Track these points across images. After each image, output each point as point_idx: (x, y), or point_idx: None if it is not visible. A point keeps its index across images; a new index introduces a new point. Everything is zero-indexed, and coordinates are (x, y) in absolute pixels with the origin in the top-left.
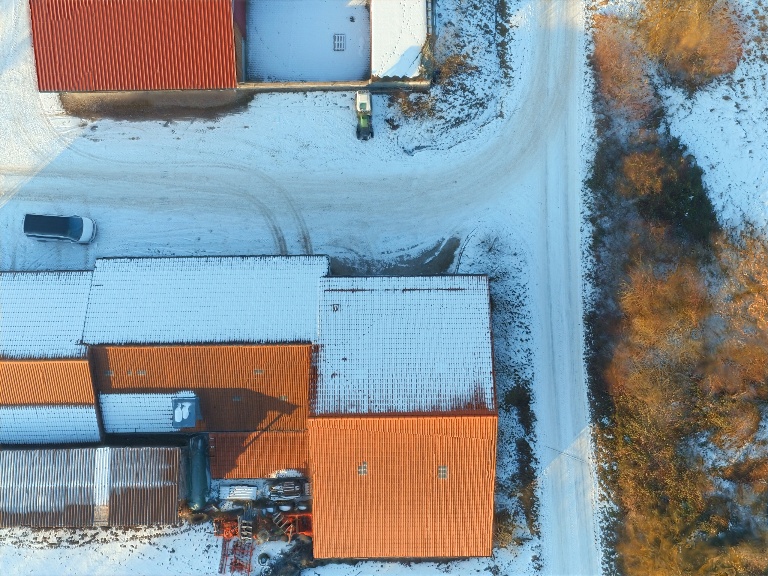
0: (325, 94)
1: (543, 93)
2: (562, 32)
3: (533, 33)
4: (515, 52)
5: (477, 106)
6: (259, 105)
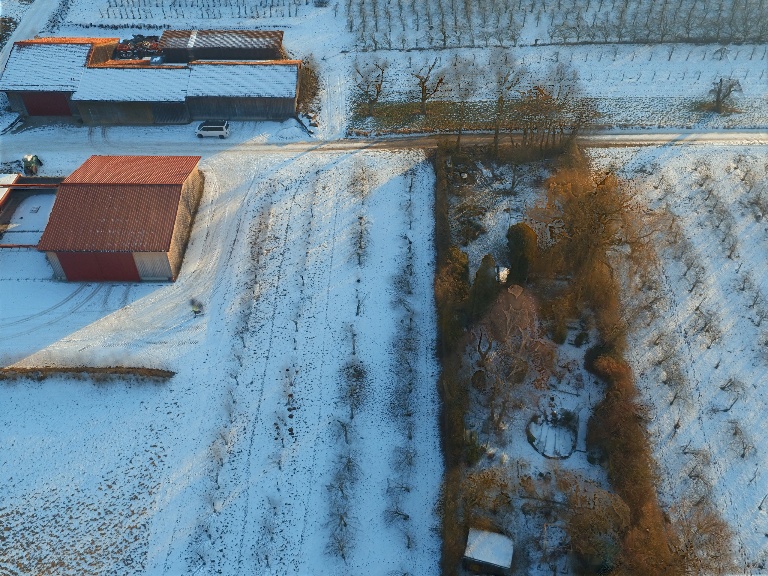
0: None
1: None
2: None
3: None
4: None
5: None
6: None
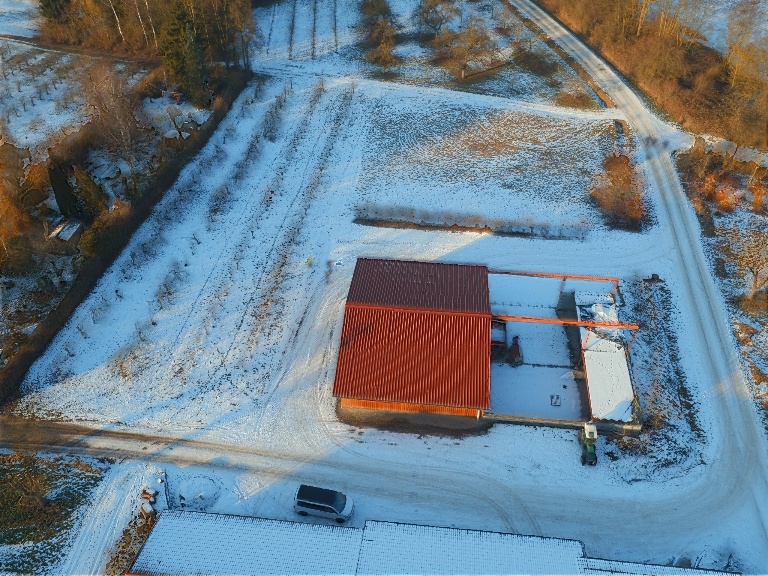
0: (552, 429)
1: (735, 450)
2: (738, 411)
3: (714, 409)
4: (703, 420)
5: (681, 453)
6: (497, 431)
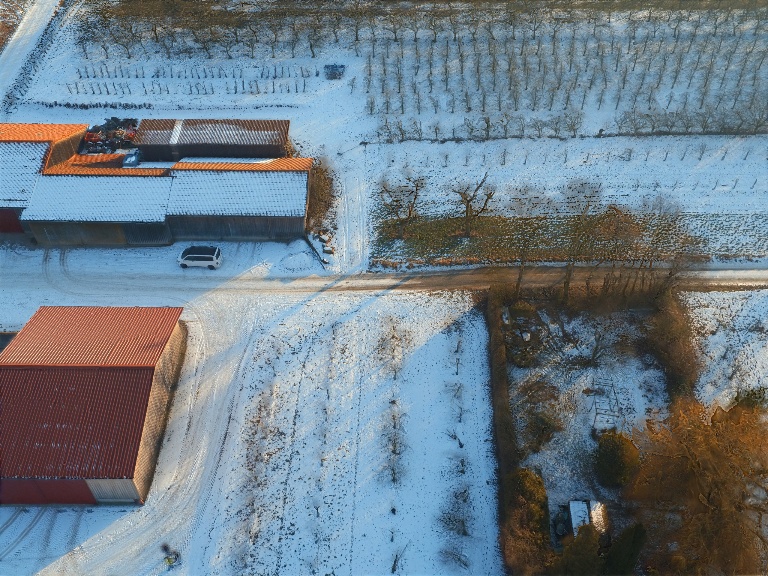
0: None
1: None
2: None
3: None
4: None
5: None
6: None
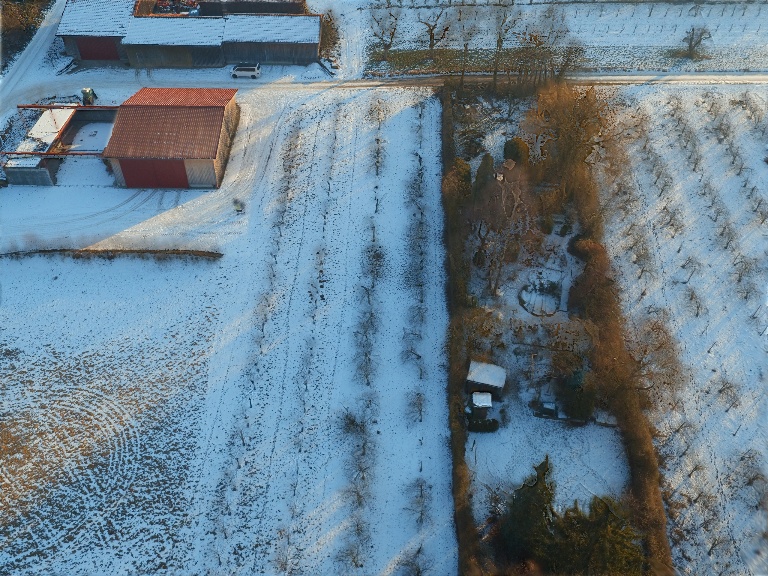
0: None
1: None
2: None
3: None
4: (2, 126)
5: None
6: None
